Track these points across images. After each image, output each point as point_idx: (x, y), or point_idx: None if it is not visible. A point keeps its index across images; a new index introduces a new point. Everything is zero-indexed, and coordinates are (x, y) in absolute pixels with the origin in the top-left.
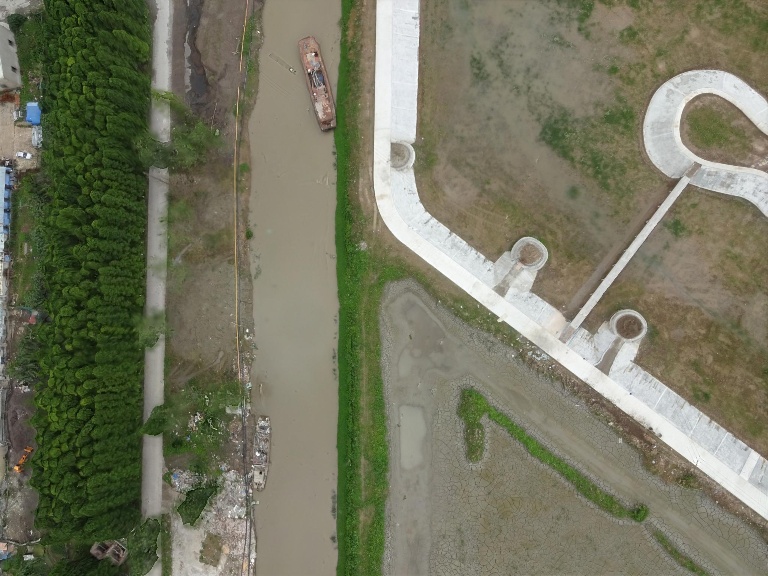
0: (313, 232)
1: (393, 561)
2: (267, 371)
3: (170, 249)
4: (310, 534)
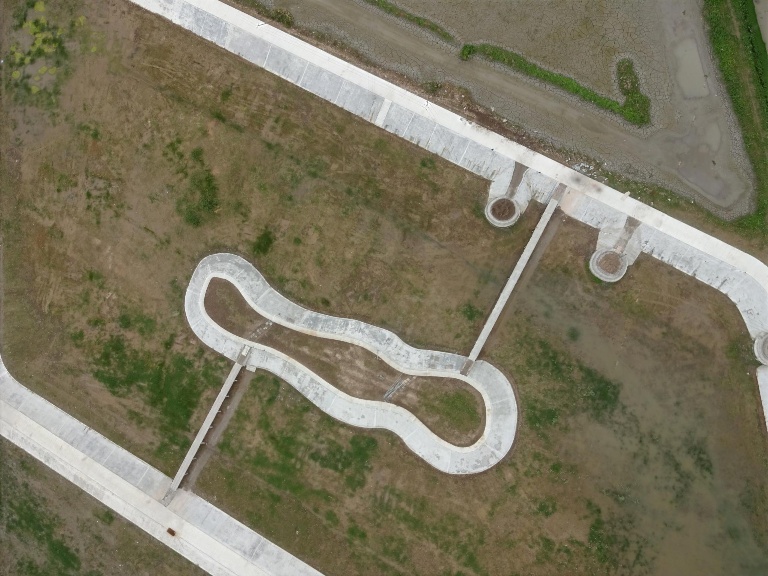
0: None
1: None
2: None
3: None
4: None
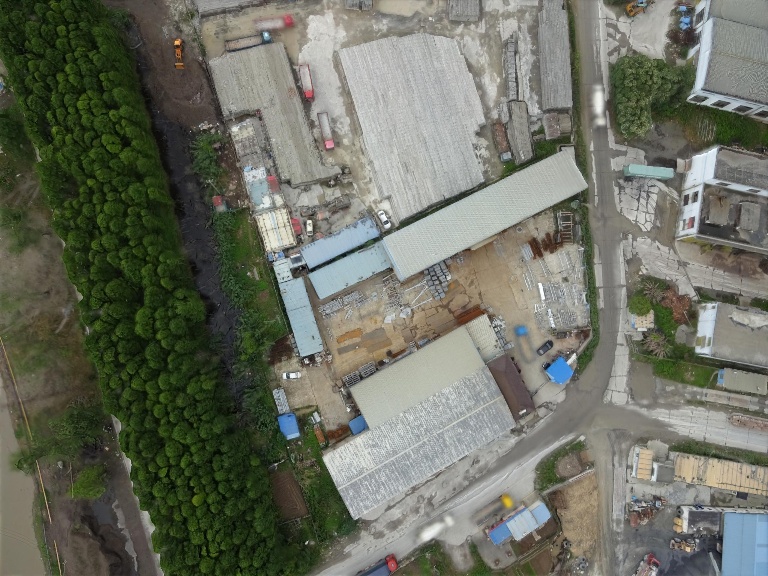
0: None
1: None
2: None
3: (79, 321)
4: None
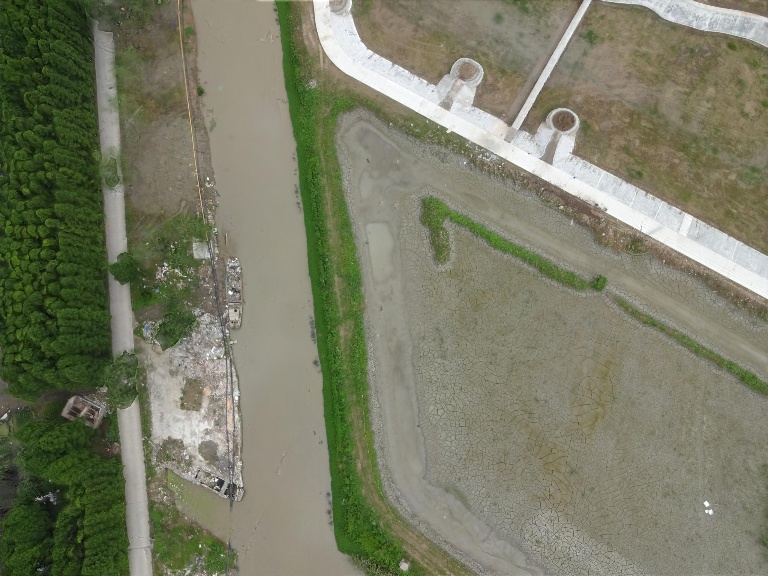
0: (263, 85)
1: (378, 371)
2: (231, 217)
3: (122, 112)
4: (292, 366)
